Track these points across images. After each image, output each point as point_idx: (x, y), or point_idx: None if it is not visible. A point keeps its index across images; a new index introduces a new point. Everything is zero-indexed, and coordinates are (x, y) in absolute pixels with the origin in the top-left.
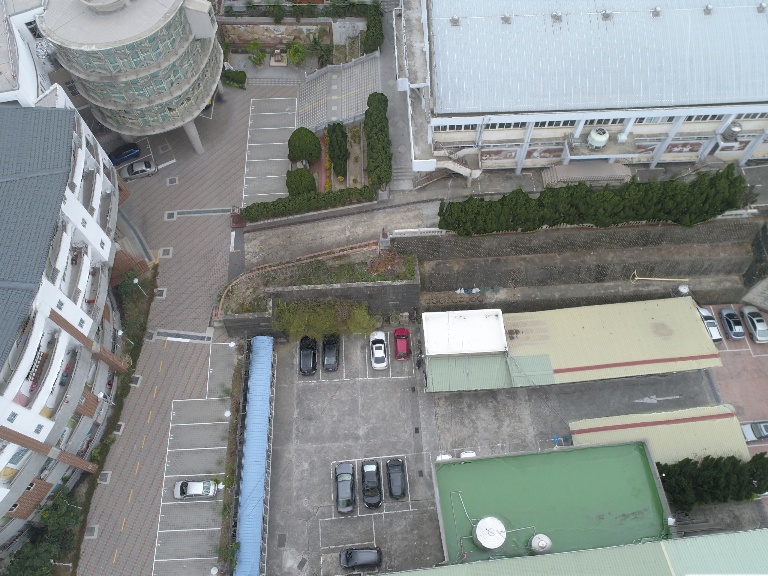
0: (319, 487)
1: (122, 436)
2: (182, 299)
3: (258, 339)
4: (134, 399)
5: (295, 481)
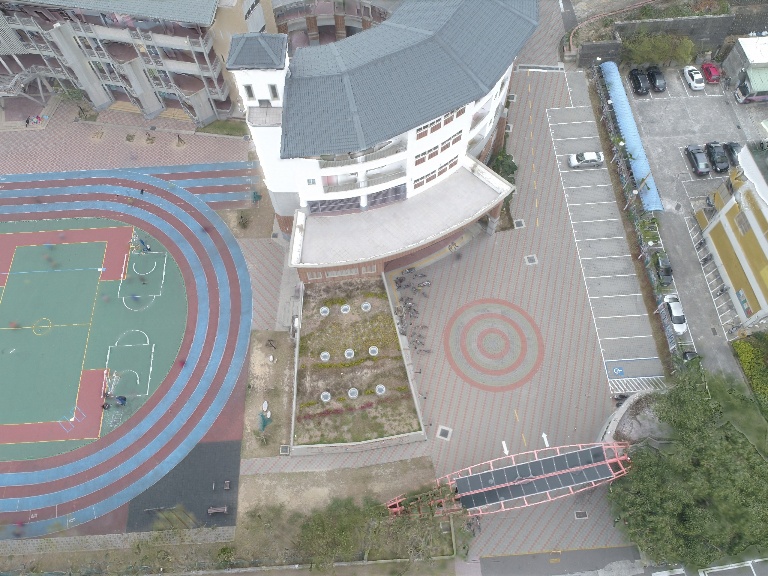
0: (675, 162)
1: (513, 133)
2: (532, 44)
3: (607, 64)
4: (515, 109)
5: (655, 159)
